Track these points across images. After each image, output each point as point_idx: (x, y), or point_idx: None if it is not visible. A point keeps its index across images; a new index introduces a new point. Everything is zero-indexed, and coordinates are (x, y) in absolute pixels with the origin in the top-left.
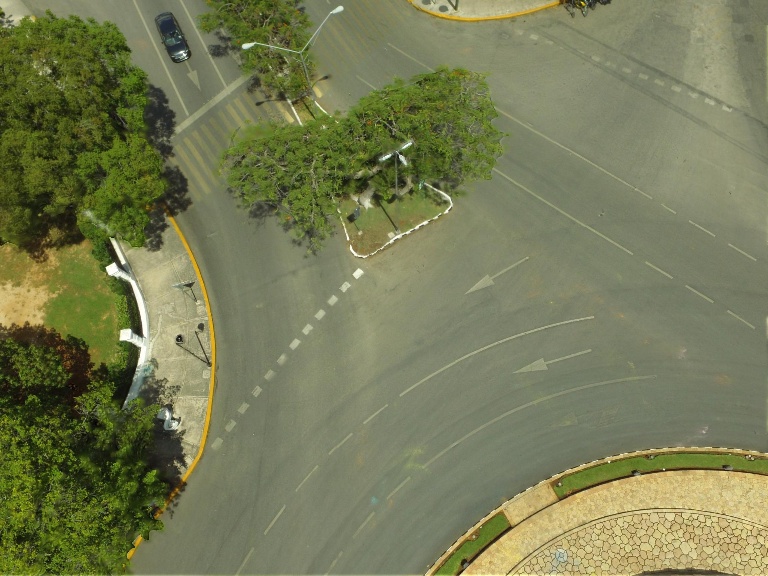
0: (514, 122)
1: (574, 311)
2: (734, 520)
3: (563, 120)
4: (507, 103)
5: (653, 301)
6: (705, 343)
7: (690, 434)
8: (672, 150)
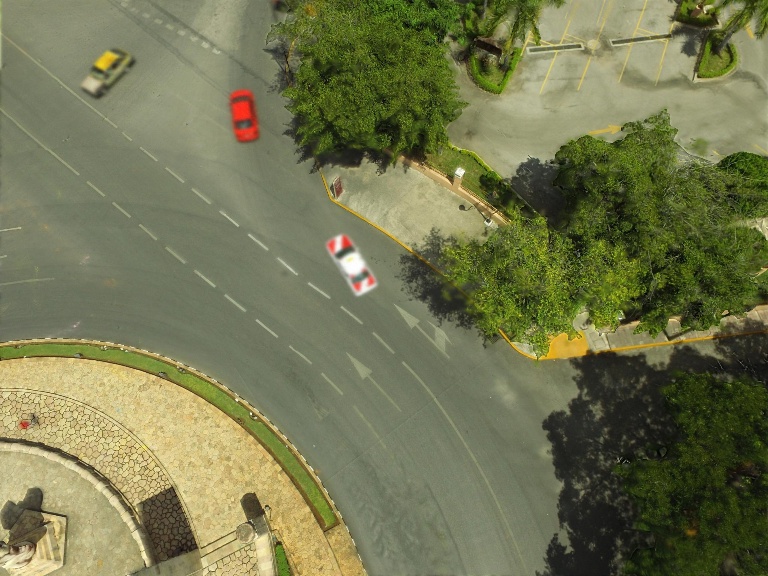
0: (27, 58)
1: (6, 222)
2: (59, 398)
3: (70, 57)
4: (28, 41)
5: (78, 215)
6: (107, 251)
7: (62, 328)
8: (152, 86)
